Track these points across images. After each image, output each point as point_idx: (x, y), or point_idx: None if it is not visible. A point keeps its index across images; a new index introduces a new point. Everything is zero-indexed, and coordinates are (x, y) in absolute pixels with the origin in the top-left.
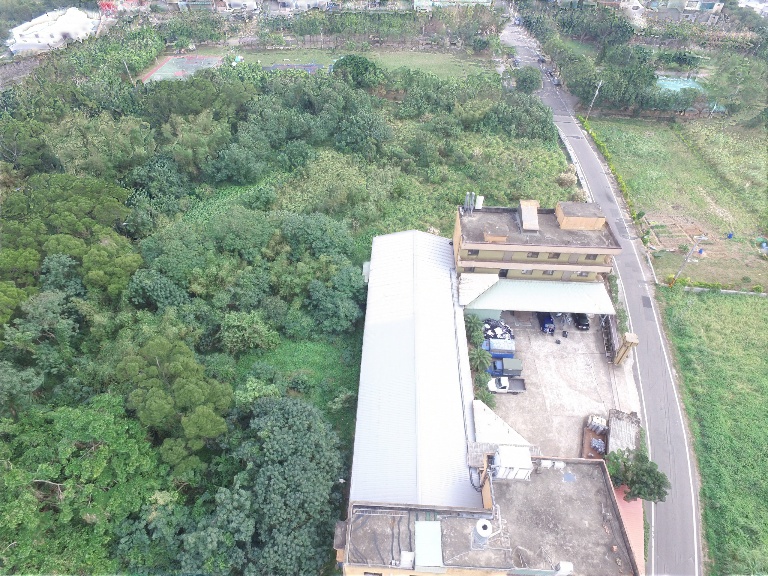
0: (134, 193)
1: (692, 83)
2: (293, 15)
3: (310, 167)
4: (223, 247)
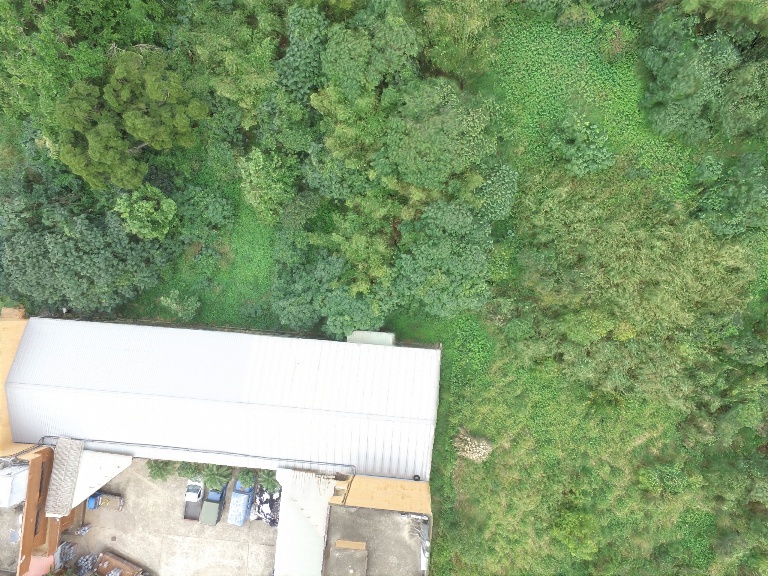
0: None
1: None
2: None
3: (684, 227)
4: None
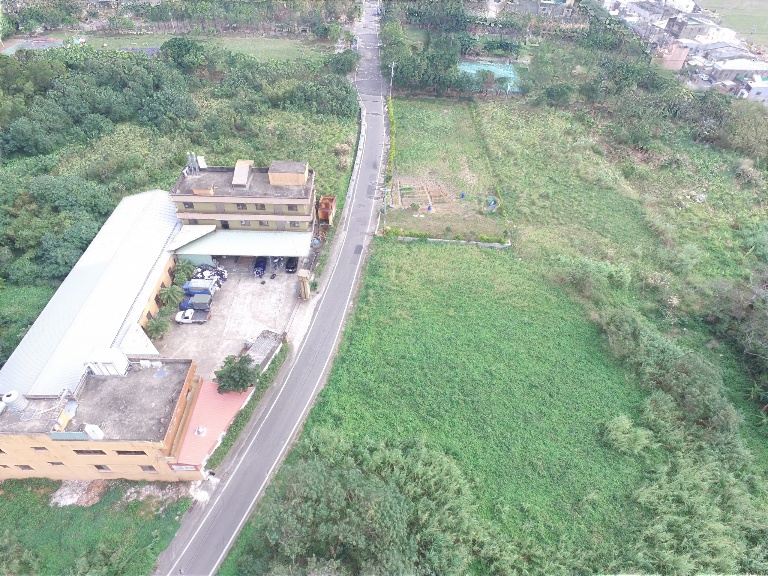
0: None
1: (513, 68)
2: (161, 2)
3: (101, 139)
4: None
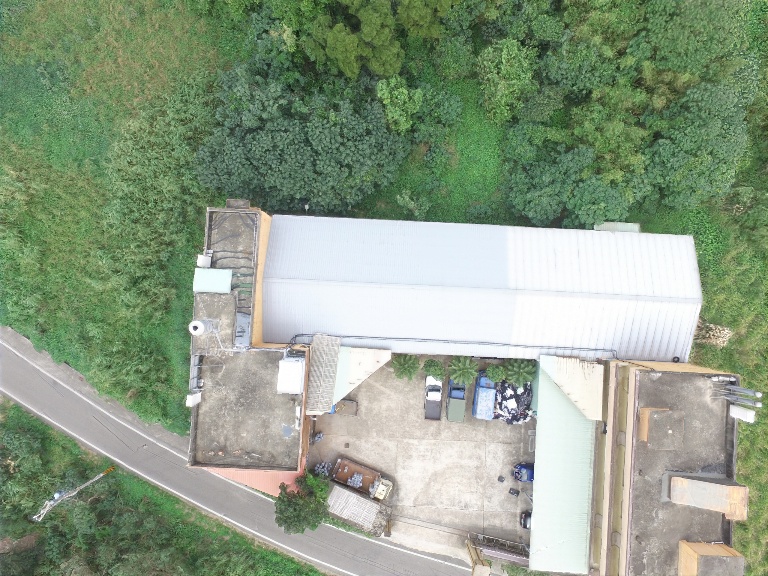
0: None
1: None
2: None
3: None
4: (651, 1)
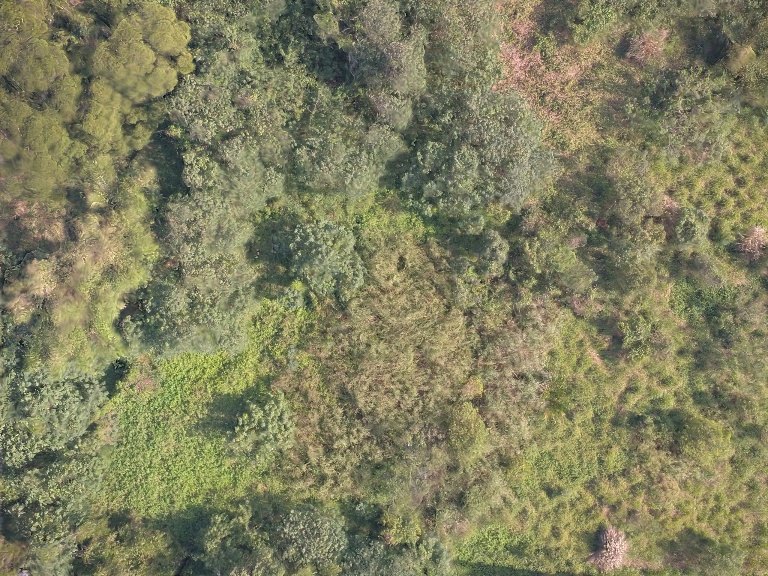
0: (3, 438)
1: None
2: None
3: (354, 319)
4: None
